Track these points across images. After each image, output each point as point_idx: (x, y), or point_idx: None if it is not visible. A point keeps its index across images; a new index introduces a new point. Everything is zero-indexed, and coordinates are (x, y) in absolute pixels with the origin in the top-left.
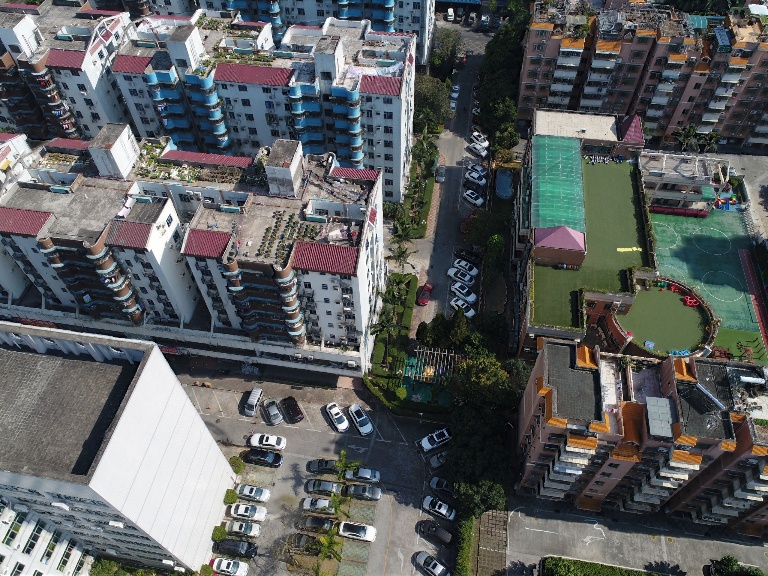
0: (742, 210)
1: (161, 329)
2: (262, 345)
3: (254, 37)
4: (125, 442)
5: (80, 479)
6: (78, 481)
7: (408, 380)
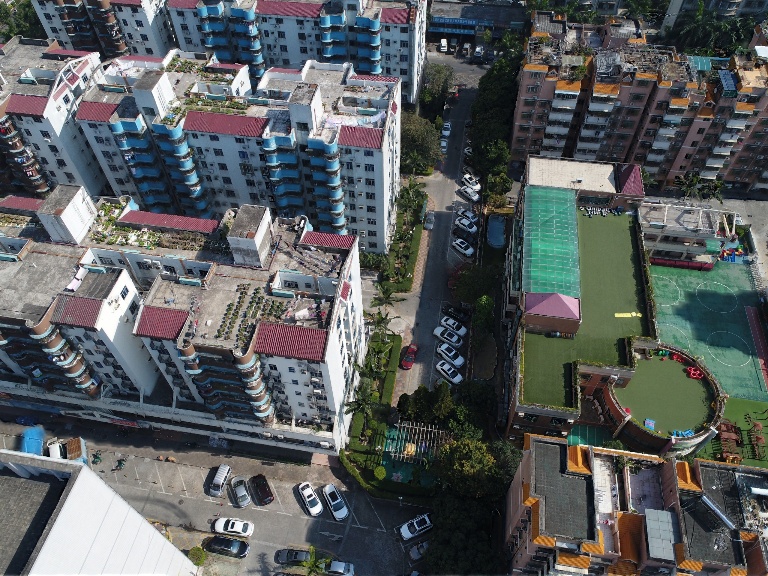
0: (749, 262)
1: (119, 403)
2: (228, 423)
3: (229, 81)
4: None
5: None
6: None
7: (388, 455)
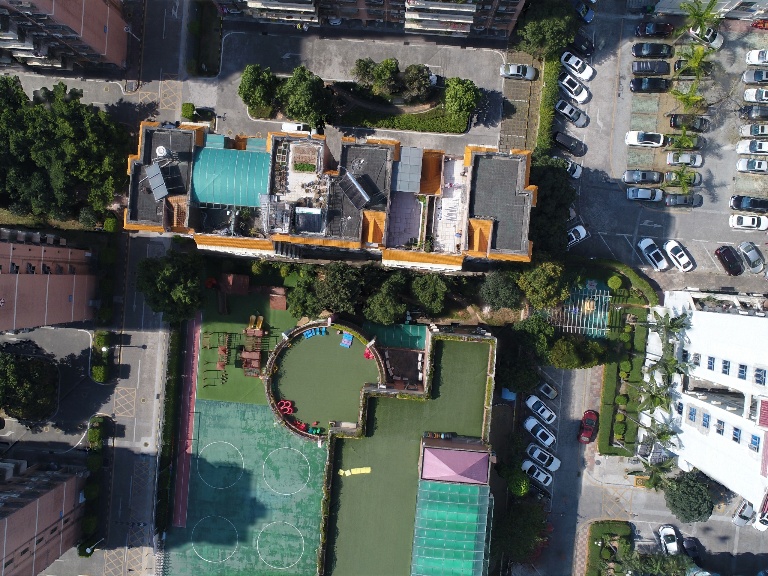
0: None
1: None
2: None
3: None
4: None
5: None
6: None
7: None
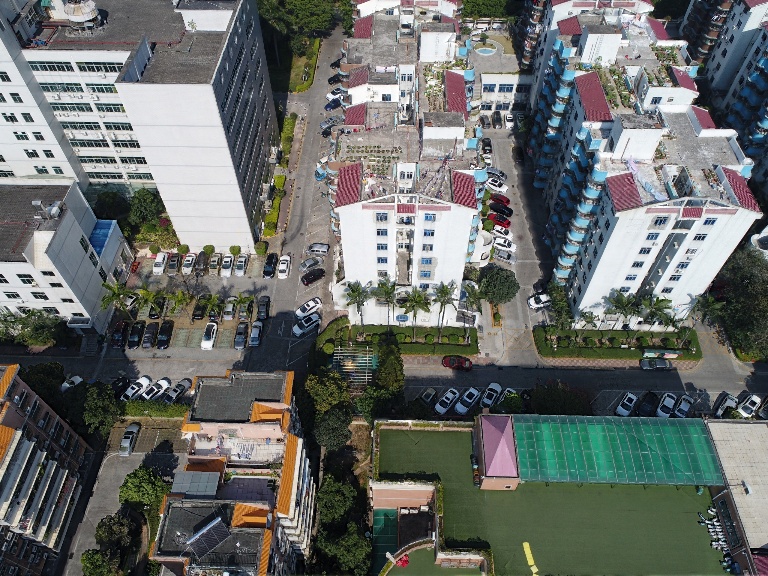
0: None
1: None
2: None
3: (660, 86)
4: (154, 99)
5: (119, 80)
6: (117, 79)
7: None
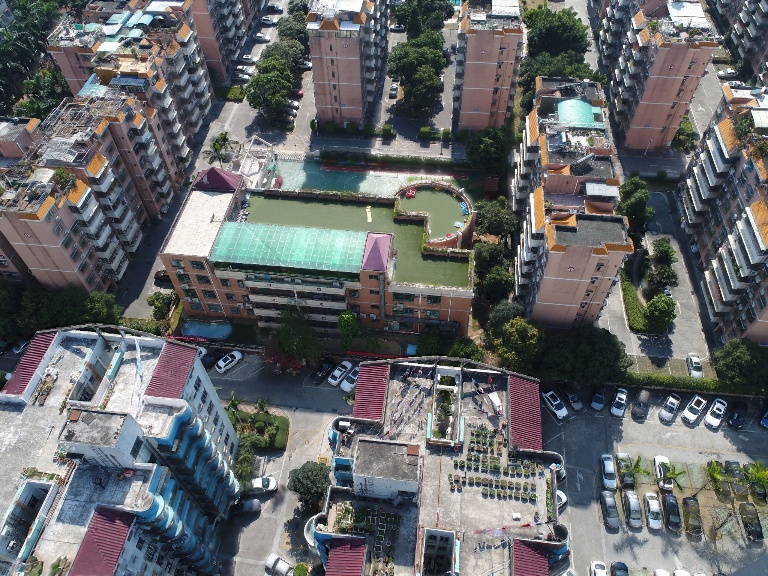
0: (275, 158)
1: None
2: None
3: None
4: None
5: None
6: None
7: None
